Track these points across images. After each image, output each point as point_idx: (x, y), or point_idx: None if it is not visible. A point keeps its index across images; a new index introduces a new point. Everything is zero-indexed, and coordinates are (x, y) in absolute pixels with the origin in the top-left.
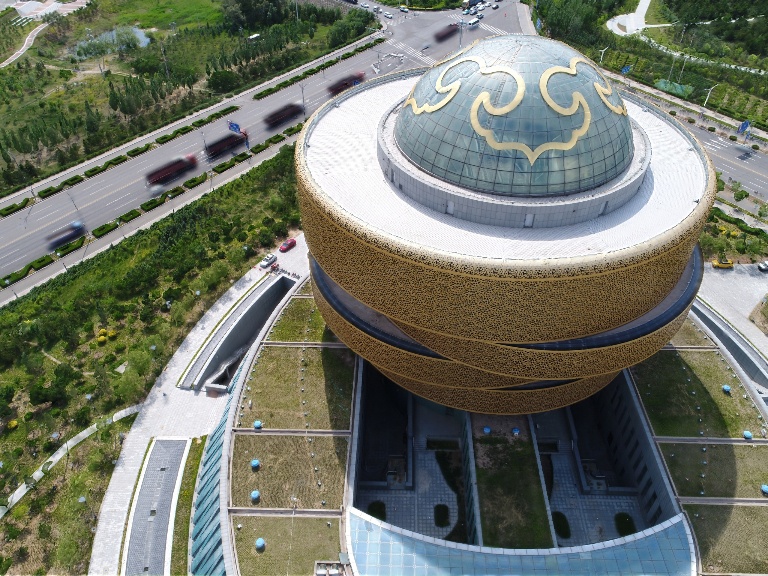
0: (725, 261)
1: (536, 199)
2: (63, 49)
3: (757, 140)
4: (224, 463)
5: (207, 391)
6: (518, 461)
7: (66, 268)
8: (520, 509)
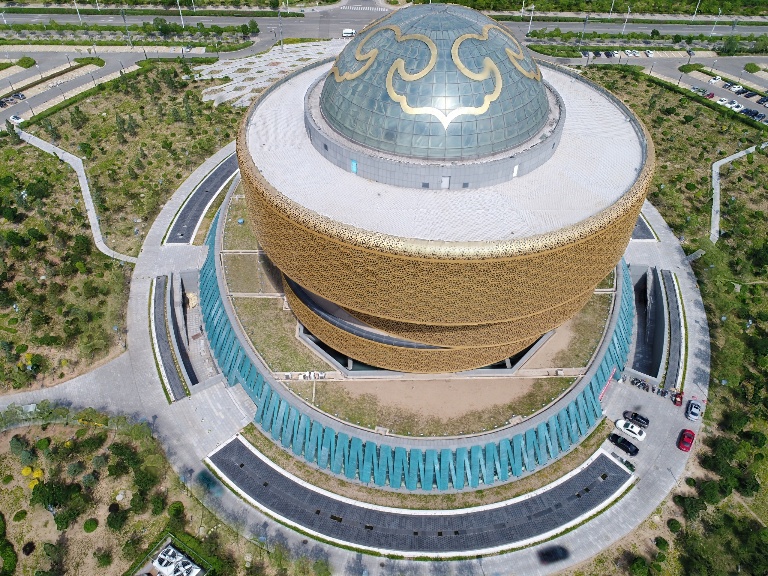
0: None
1: None
2: None
3: None
4: None
5: None
6: None
7: None
8: None
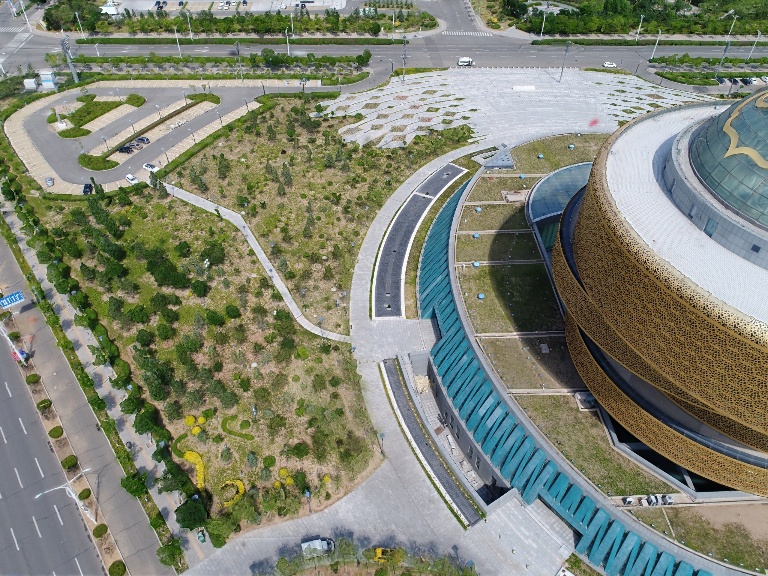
0: (386, 551)
1: None
2: None
3: None
4: None
5: None
6: None
7: None
8: None
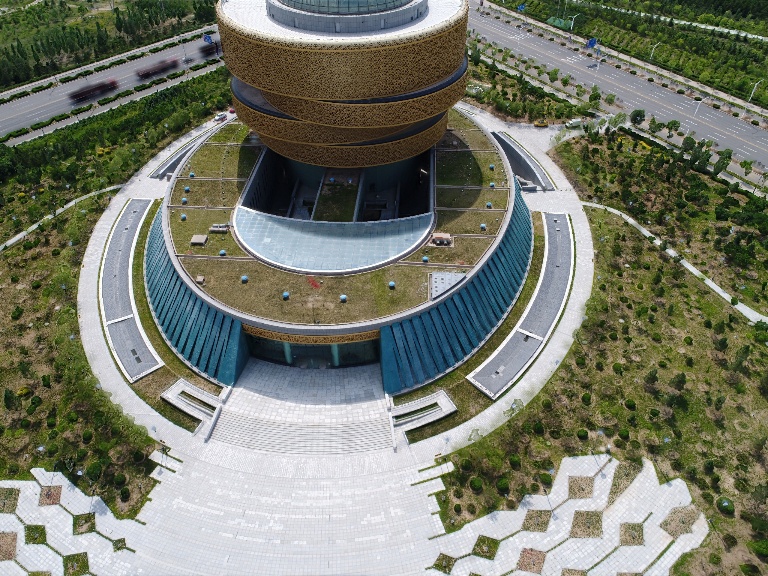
0: (542, 121)
1: (342, 15)
2: None
3: (608, 57)
4: (169, 189)
5: (168, 179)
6: (346, 192)
7: (78, 119)
8: (339, 209)
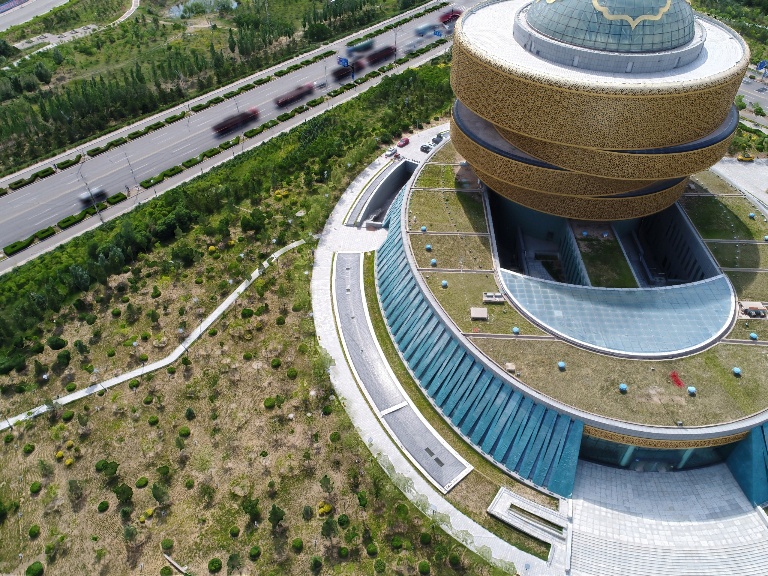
0: (747, 155)
1: (634, 53)
2: (164, 10)
3: None
4: (407, 247)
5: (366, 227)
6: (609, 249)
7: None
8: (614, 271)
